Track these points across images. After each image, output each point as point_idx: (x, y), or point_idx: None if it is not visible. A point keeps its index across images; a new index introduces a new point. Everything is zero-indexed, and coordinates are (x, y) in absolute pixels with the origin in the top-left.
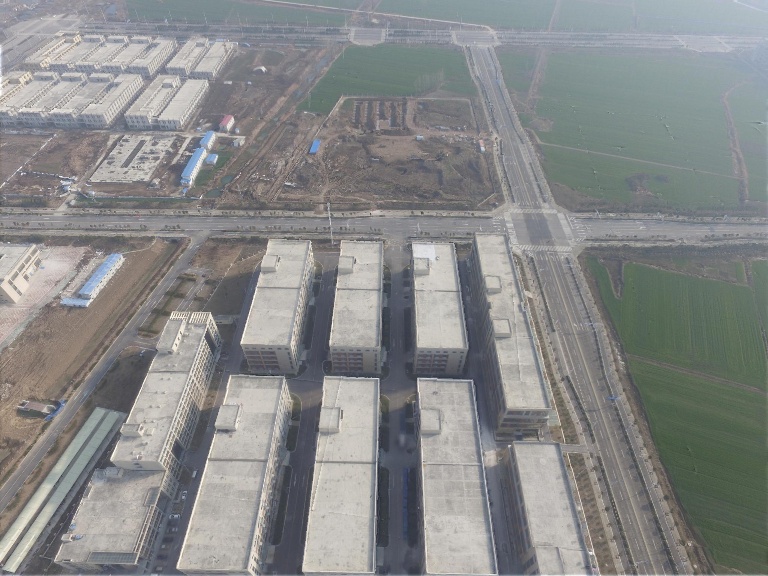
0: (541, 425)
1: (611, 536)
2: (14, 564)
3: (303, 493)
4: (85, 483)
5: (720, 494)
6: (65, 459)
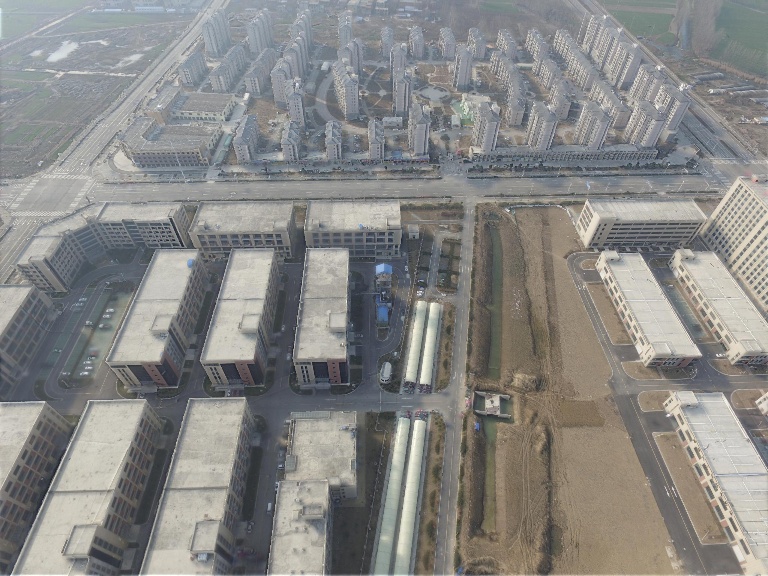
0: None
1: None
2: (402, 422)
3: (158, 495)
4: (379, 493)
5: None
6: (408, 513)
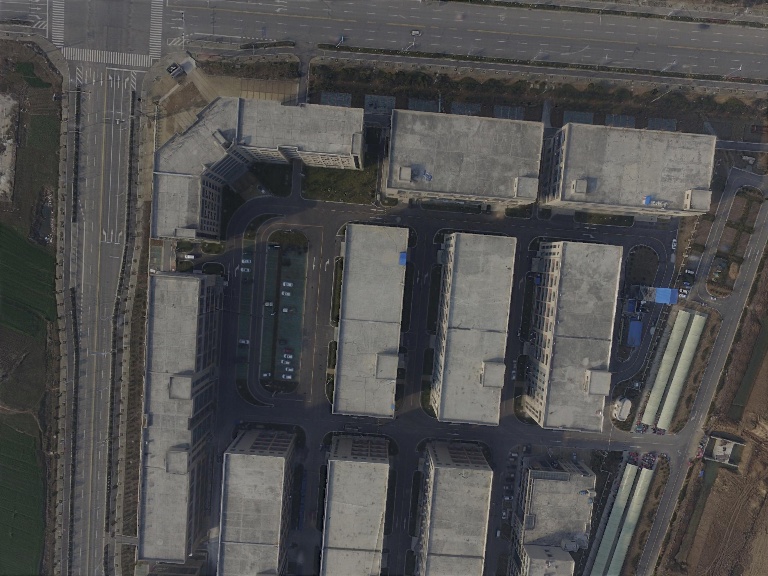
0: (154, 570)
1: (121, 463)
2: (630, 470)
3: (397, 512)
4: (596, 530)
5: (1, 492)
6: (621, 554)
